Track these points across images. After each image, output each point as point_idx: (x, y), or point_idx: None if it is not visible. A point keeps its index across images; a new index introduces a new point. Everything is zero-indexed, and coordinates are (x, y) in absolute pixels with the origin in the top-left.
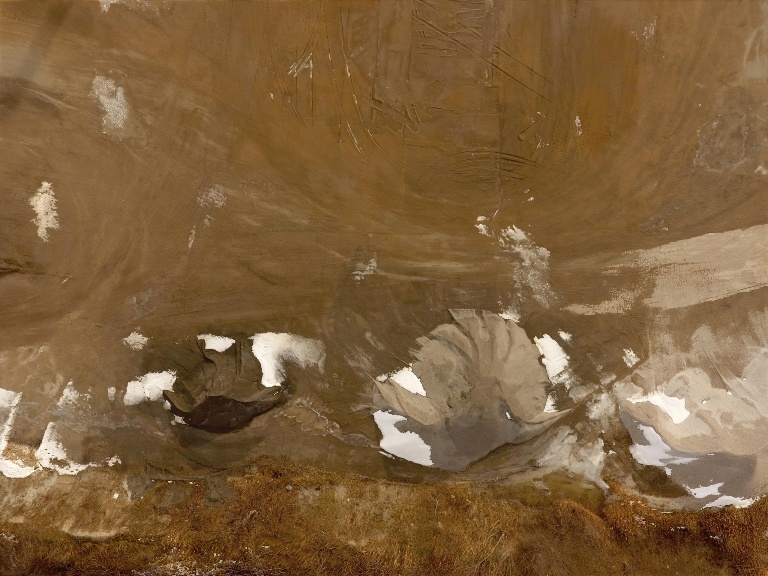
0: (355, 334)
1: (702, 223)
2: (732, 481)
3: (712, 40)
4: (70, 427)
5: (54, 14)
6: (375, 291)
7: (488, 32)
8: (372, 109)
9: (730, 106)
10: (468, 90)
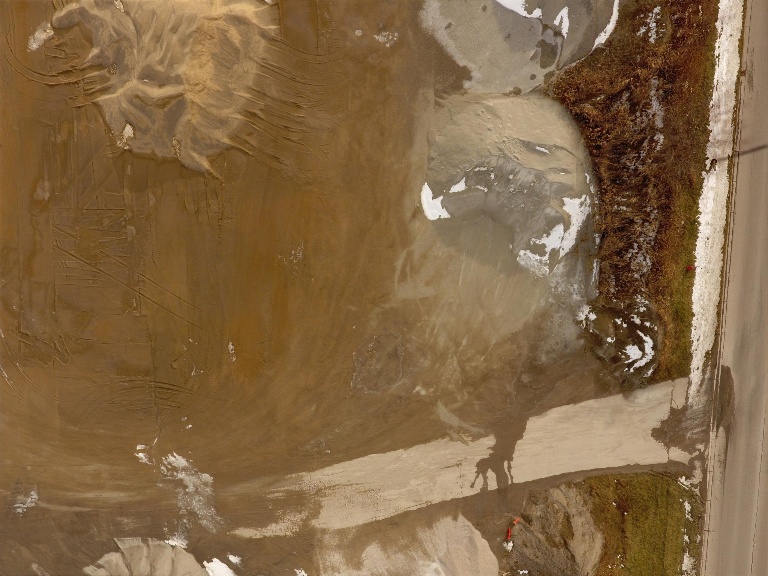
0: (22, 566)
1: (363, 445)
2: None
3: (361, 262)
4: None
5: None
6: (38, 523)
7: (132, 260)
8: (19, 342)
9: (384, 327)
10: (116, 320)
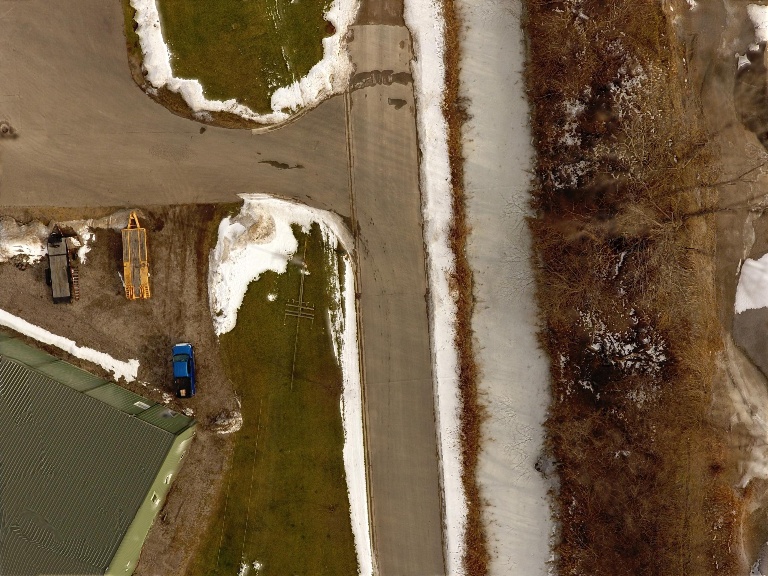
0: None
1: None
2: None
3: None
4: None
5: None
6: None
7: None
8: None
9: None
10: None
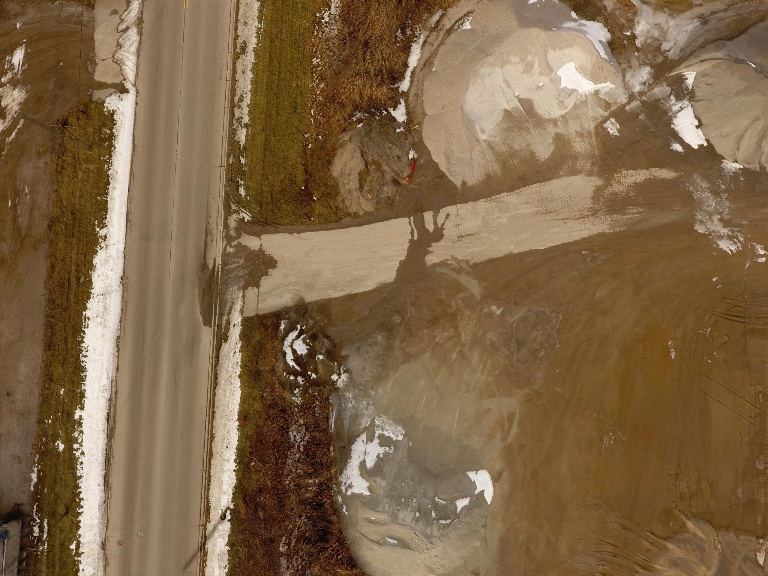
0: None
1: (551, 258)
2: (524, 4)
3: (550, 432)
4: None
5: None
6: None
7: (760, 437)
8: None
9: (529, 370)
10: None
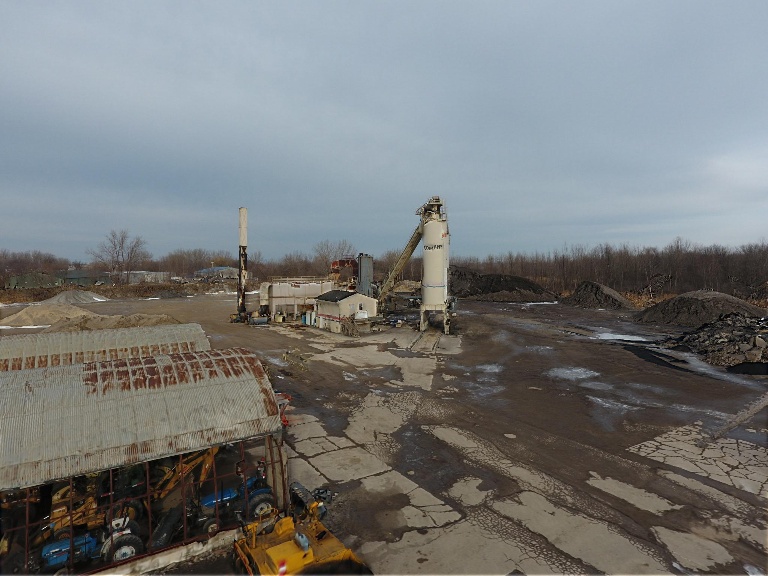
0: None
1: None
2: None
3: None
4: None
5: None
6: None
7: None
8: None
9: None
10: None
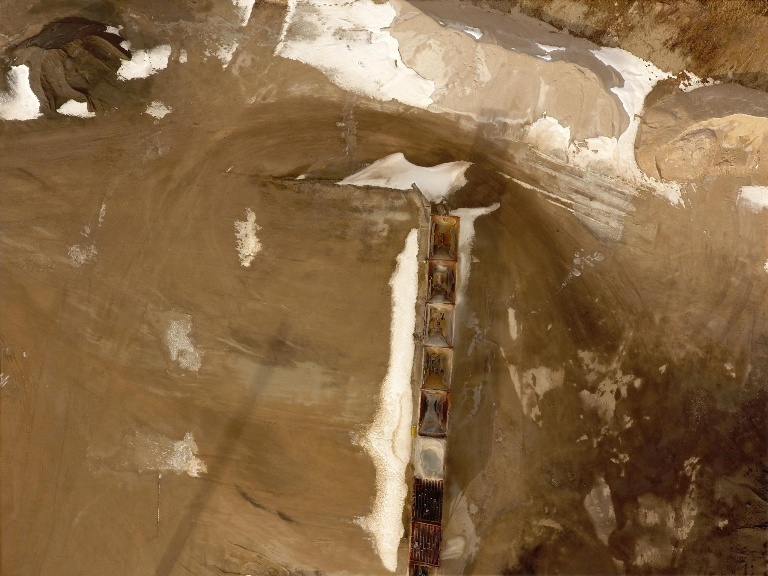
0: None
1: None
2: None
3: None
4: (225, 21)
5: (235, 428)
6: None
7: None
8: None
9: None
10: None
